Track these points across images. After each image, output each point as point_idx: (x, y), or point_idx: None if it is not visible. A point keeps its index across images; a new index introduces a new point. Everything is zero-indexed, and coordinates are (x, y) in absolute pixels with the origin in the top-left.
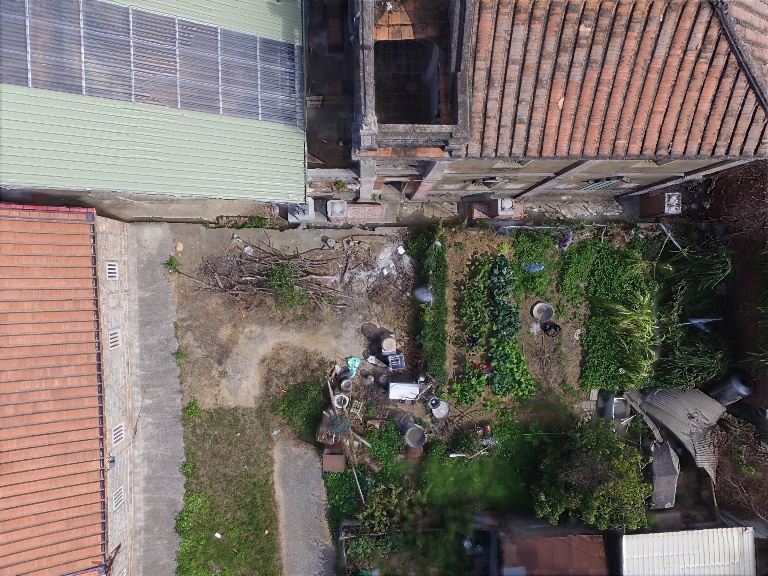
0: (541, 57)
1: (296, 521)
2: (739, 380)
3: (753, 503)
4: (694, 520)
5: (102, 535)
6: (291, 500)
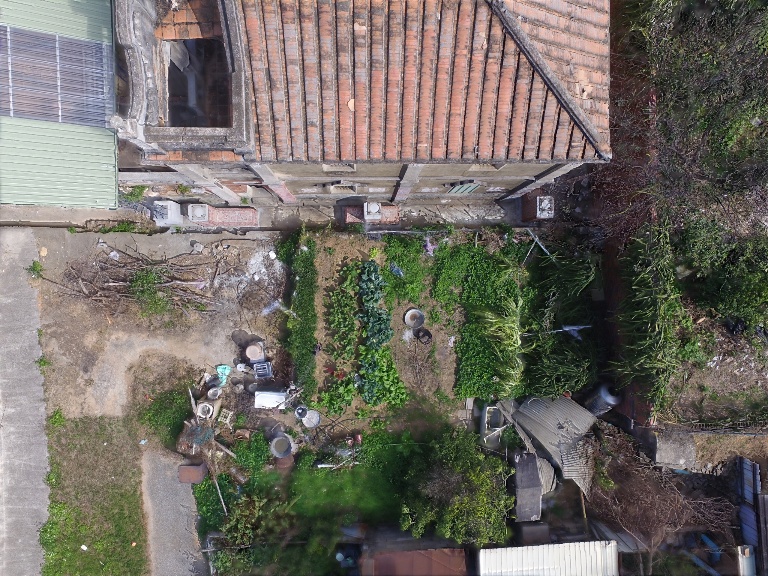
0: (320, 57)
1: (165, 533)
2: (607, 389)
3: (619, 516)
4: (568, 532)
5: None
6: (160, 511)
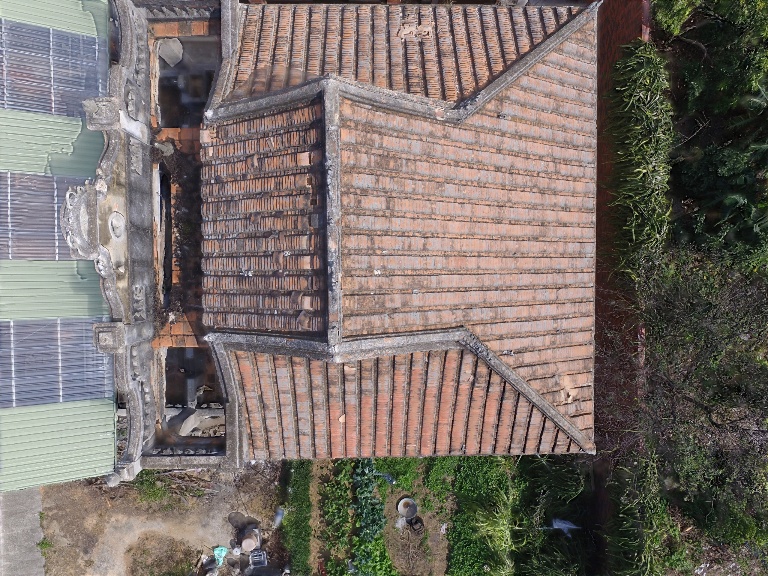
0: (312, 387)
1: None
2: None
3: None
4: None
5: None
6: None
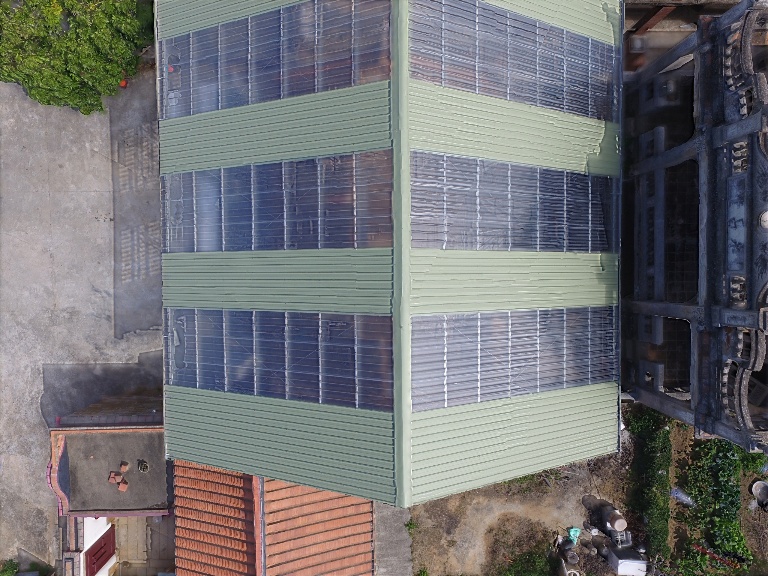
0: None
1: None
2: None
3: None
4: None
5: None
6: None
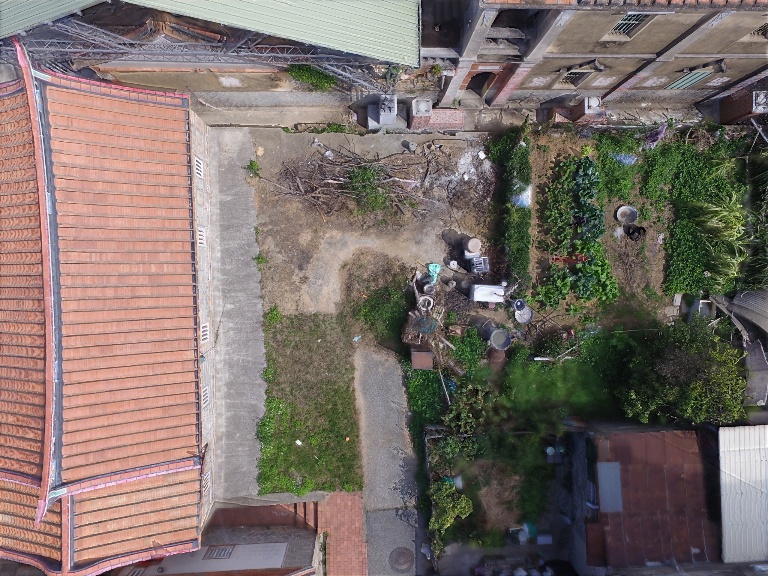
0: None
1: (376, 429)
2: None
3: None
4: None
5: (196, 425)
6: (371, 407)
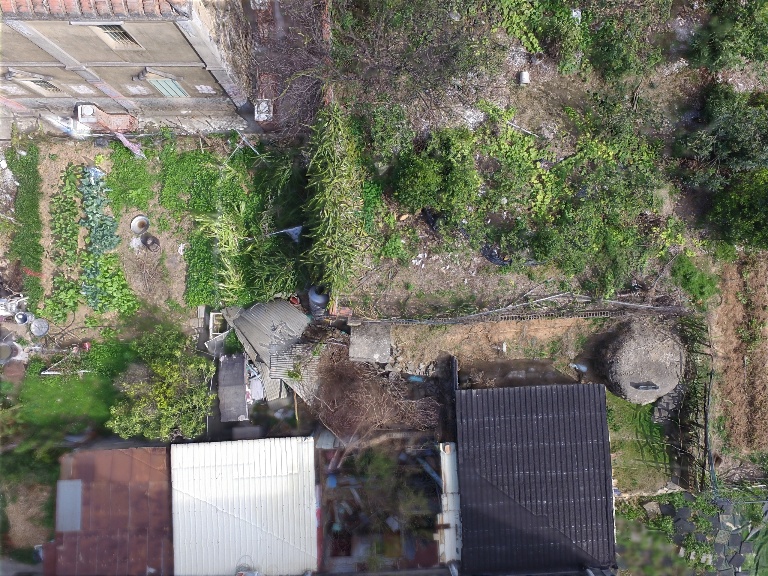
0: None
1: None
2: (314, 288)
3: (322, 414)
4: None
5: None
6: None
